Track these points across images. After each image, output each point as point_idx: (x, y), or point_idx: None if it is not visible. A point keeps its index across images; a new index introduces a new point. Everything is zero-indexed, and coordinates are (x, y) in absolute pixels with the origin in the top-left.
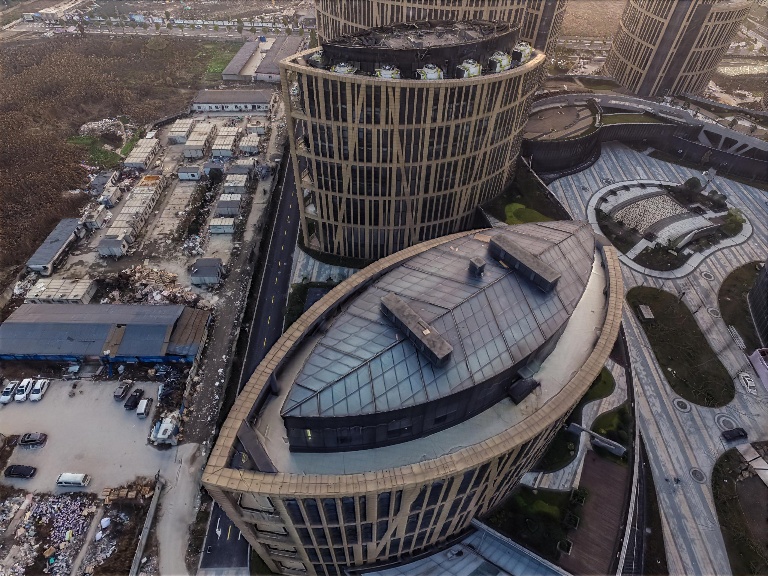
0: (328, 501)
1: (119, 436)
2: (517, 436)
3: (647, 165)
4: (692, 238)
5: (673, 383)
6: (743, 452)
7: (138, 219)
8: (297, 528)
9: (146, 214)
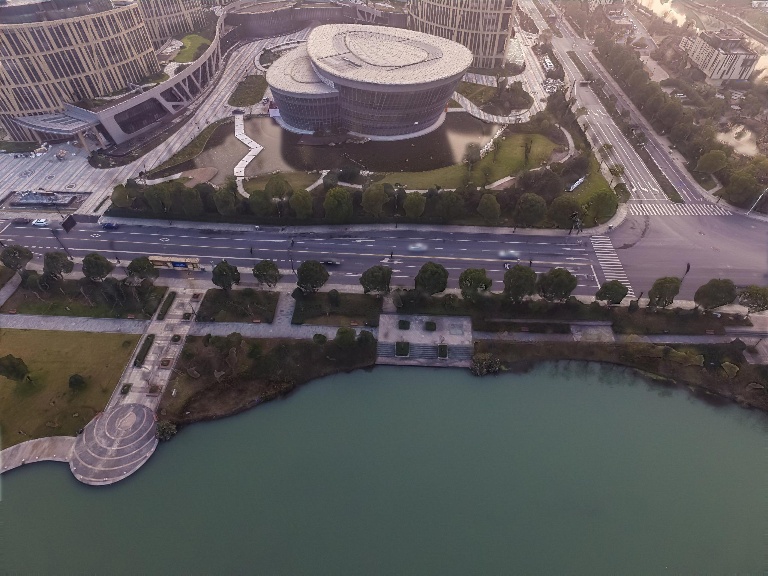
0: None
1: None
2: None
3: None
4: None
5: (230, 101)
6: None
7: None
8: None
9: None
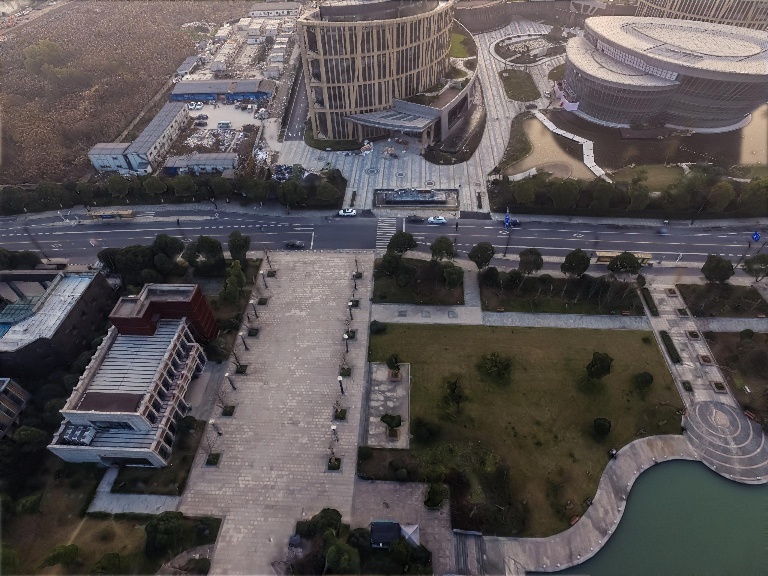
0: (334, 34)
1: (240, 117)
2: (394, 19)
3: (537, 27)
4: (547, 52)
5: (509, 96)
6: (533, 111)
7: (230, 55)
8: (324, 62)
9: (233, 55)
